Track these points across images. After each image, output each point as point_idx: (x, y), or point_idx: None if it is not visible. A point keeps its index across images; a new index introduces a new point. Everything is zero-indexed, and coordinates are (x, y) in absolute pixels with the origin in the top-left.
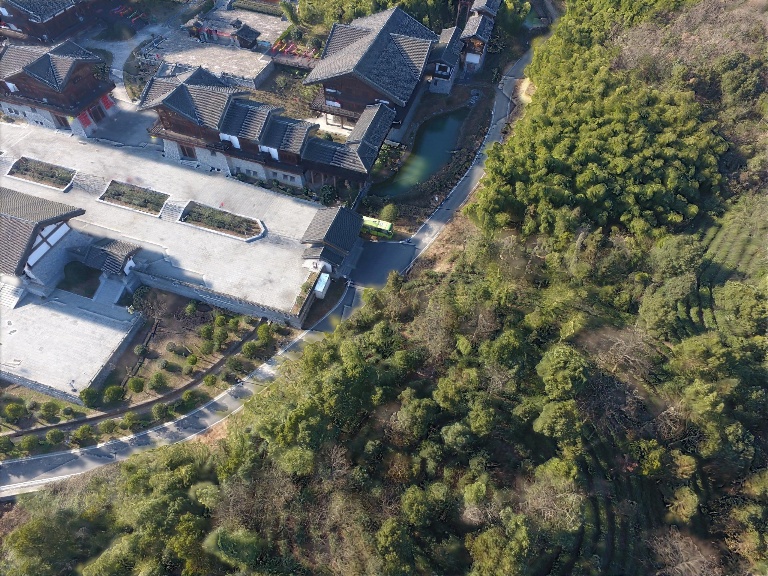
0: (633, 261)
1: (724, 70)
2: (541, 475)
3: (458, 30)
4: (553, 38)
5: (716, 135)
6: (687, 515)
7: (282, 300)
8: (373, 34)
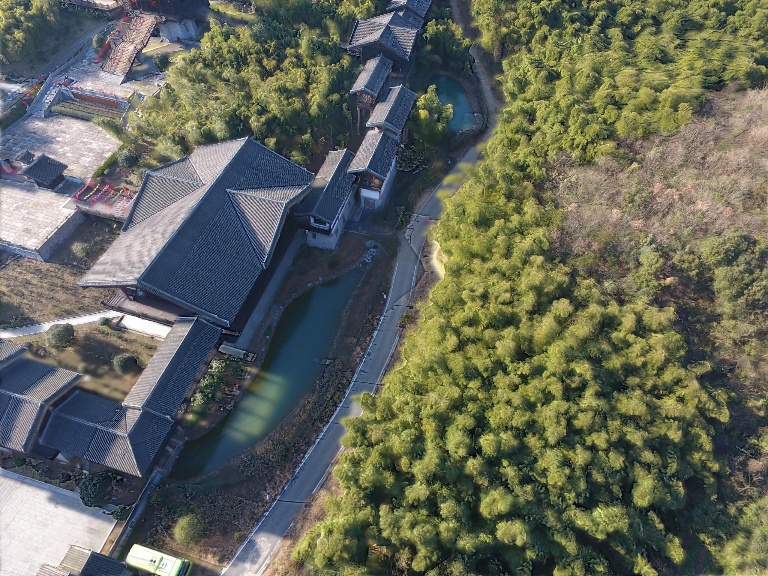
0: None
1: (718, 263)
2: None
3: (349, 154)
4: (471, 185)
5: (709, 388)
6: None
7: None
8: (200, 192)
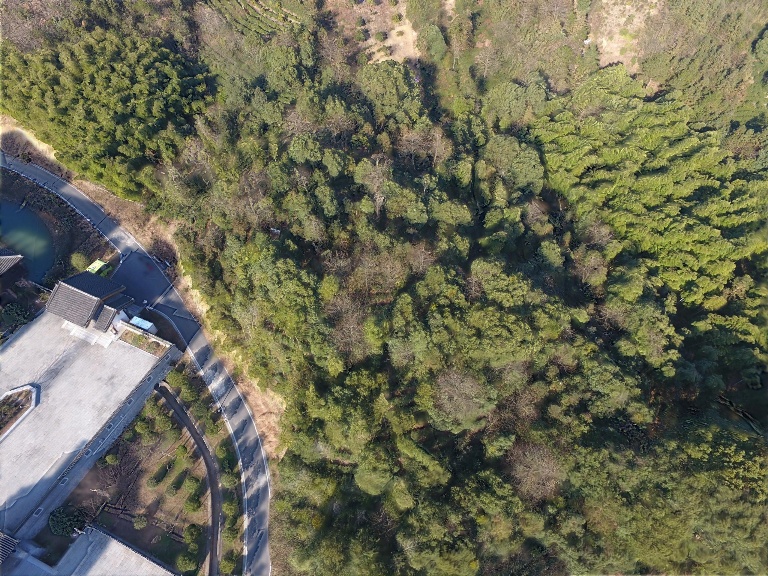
0: (228, 117)
1: (87, 5)
2: (362, 179)
3: None
4: None
5: None
6: (390, 142)
7: (142, 366)
8: None
